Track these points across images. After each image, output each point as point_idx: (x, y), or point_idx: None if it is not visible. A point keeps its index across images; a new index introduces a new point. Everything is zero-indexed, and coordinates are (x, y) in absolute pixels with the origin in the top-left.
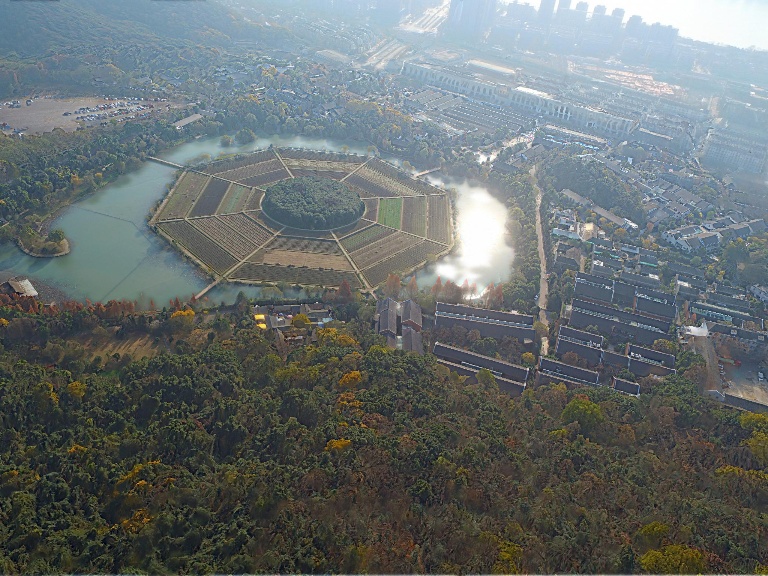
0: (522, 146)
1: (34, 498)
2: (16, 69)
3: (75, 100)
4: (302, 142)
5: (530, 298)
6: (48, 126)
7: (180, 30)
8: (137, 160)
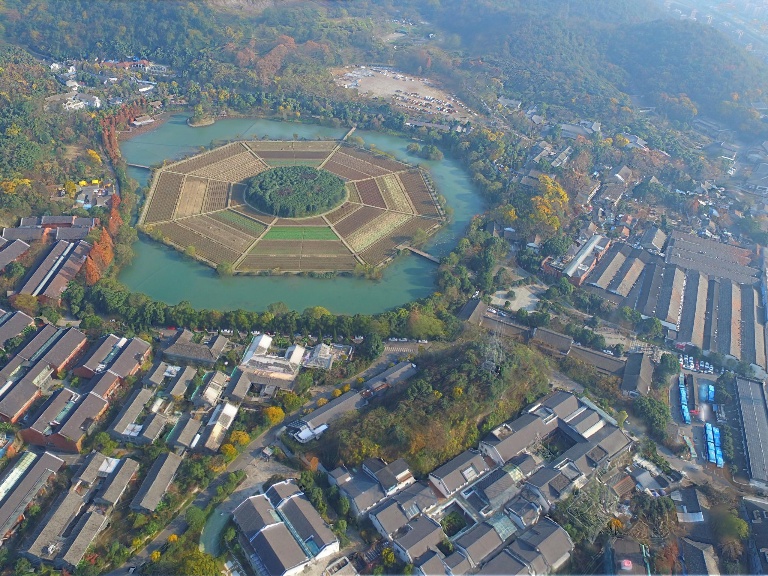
0: (589, 337)
1: None
2: (436, 59)
3: (432, 90)
4: (451, 181)
5: None
6: None
7: (650, 88)
8: (336, 121)
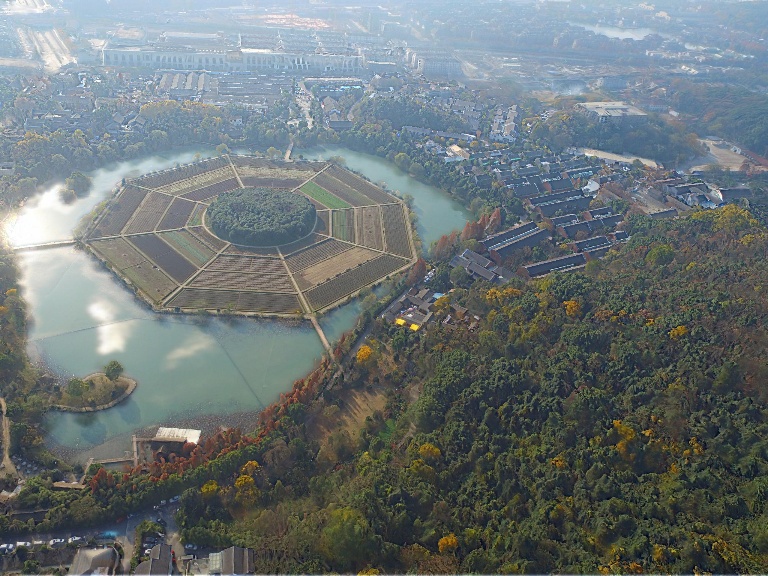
0: None
1: None
2: None
3: None
4: (140, 166)
5: None
6: None
7: None
8: (17, 257)
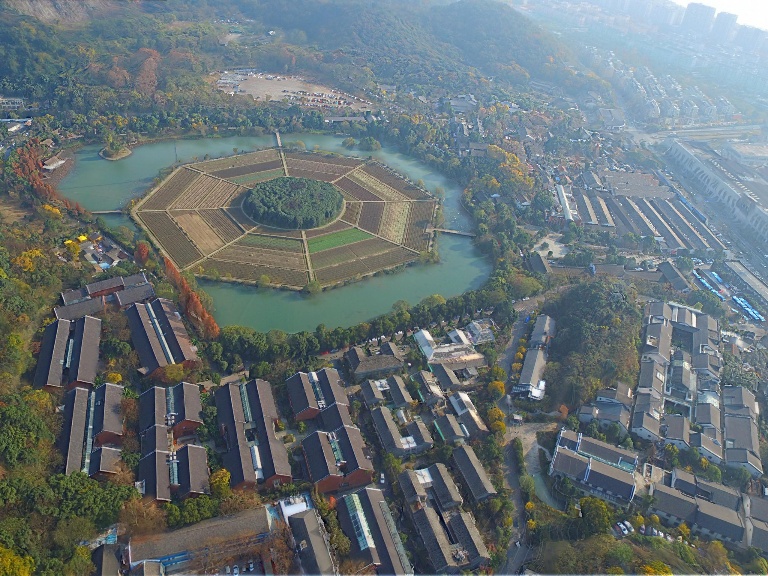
0: (626, 261)
1: None
2: (299, 55)
3: (312, 86)
4: (407, 166)
5: (253, 358)
6: (259, 94)
7: (485, 60)
8: (258, 130)
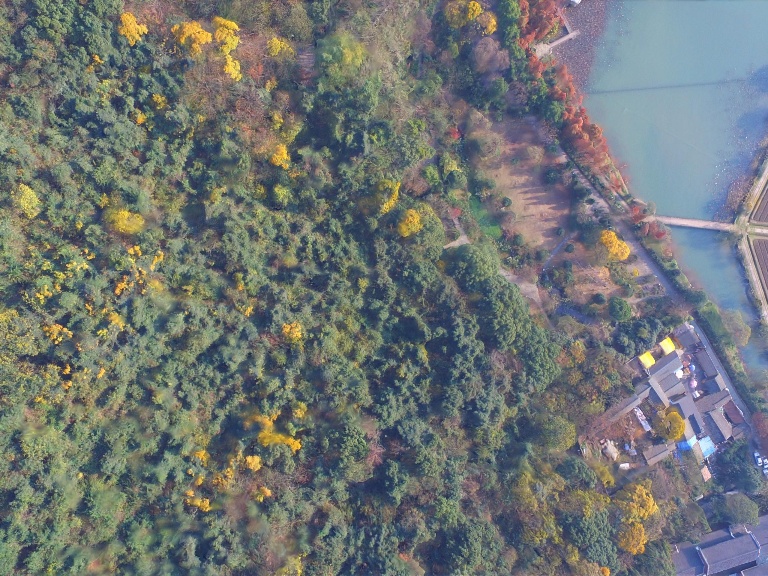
0: None
1: (207, 346)
2: None
3: None
4: None
5: None
6: None
7: None
8: None
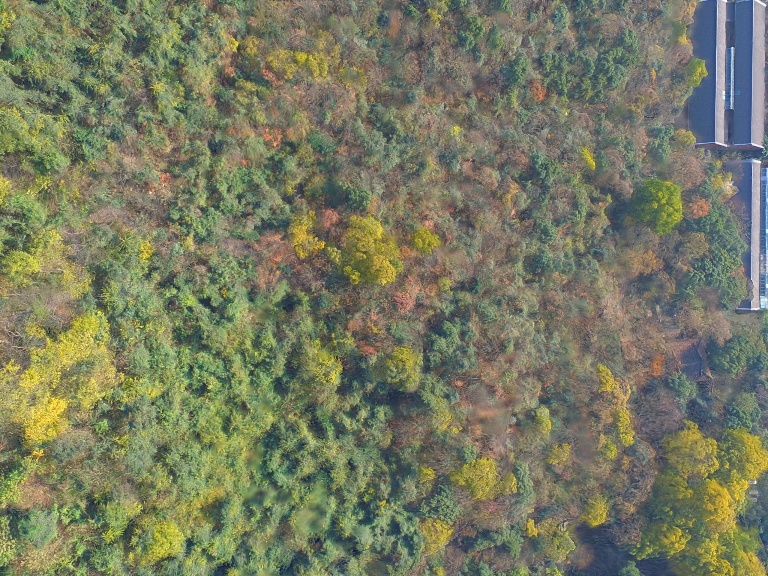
0: None
1: None
2: None
3: None
4: None
5: None
6: None
7: None
8: None
